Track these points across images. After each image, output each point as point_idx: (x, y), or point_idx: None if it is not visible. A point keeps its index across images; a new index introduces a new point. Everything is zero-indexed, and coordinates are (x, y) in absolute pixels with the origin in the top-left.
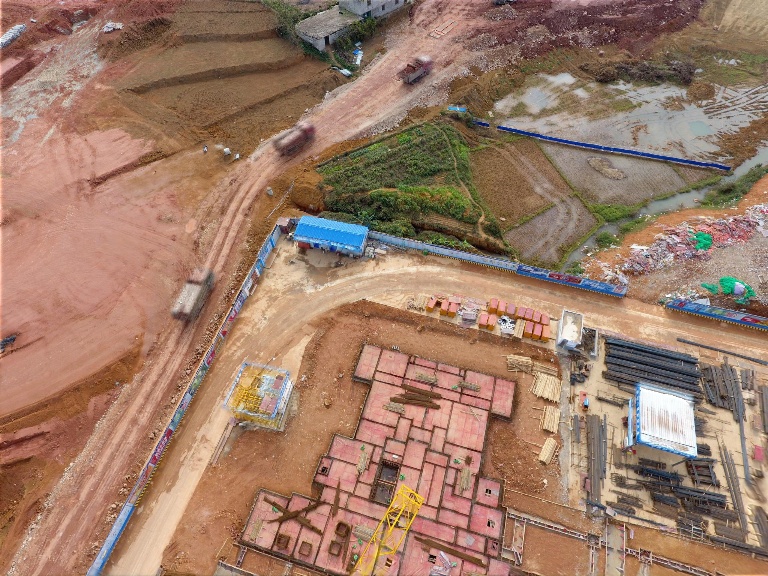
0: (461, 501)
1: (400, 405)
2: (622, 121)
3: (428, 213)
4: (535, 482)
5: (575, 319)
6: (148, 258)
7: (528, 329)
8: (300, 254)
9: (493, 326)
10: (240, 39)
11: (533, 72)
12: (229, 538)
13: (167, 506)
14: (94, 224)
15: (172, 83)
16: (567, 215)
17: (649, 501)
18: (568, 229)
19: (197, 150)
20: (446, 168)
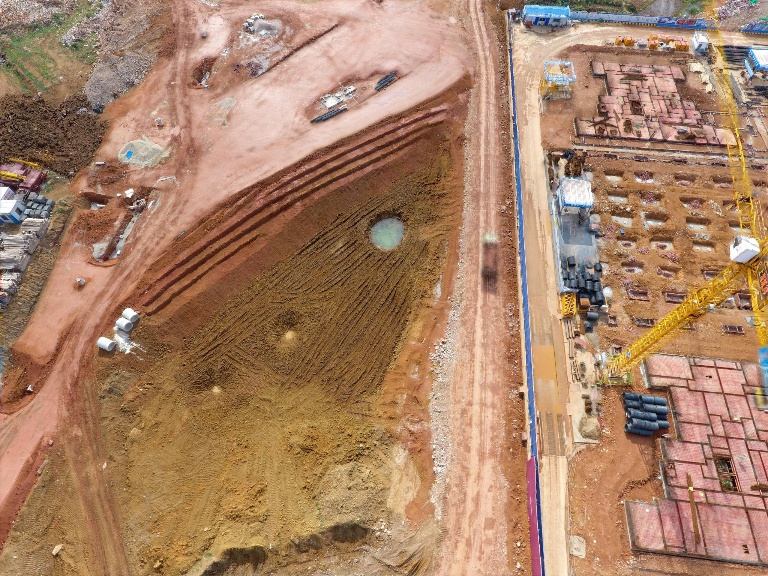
0: (678, 109)
1: (627, 80)
2: None
3: (590, 4)
4: (709, 100)
5: (703, 34)
6: (441, 35)
7: (678, 43)
8: (527, 28)
9: (656, 47)
10: None
11: None
12: (571, 135)
13: (530, 130)
14: (396, 21)
15: None
16: (667, 2)
17: (765, 99)
18: (671, 9)
19: None
20: None
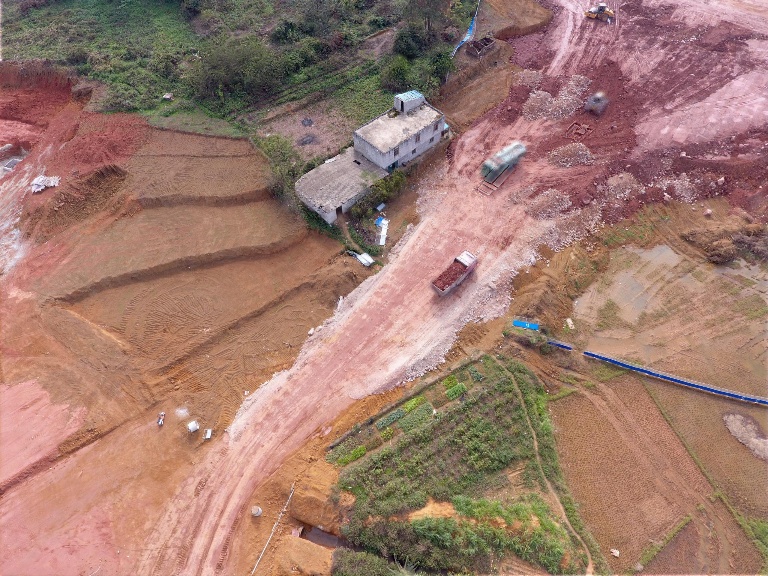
0: None
1: None
2: (759, 340)
3: (503, 556)
4: None
5: None
6: None
7: None
8: None
9: None
10: (219, 203)
11: (619, 244)
12: None
13: None
14: None
15: (121, 282)
16: (713, 544)
17: None
18: None
19: (149, 421)
20: (523, 455)
